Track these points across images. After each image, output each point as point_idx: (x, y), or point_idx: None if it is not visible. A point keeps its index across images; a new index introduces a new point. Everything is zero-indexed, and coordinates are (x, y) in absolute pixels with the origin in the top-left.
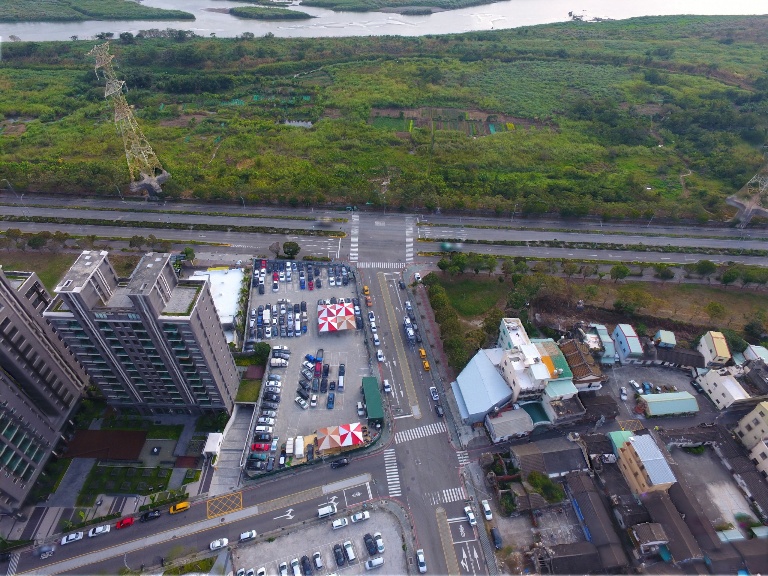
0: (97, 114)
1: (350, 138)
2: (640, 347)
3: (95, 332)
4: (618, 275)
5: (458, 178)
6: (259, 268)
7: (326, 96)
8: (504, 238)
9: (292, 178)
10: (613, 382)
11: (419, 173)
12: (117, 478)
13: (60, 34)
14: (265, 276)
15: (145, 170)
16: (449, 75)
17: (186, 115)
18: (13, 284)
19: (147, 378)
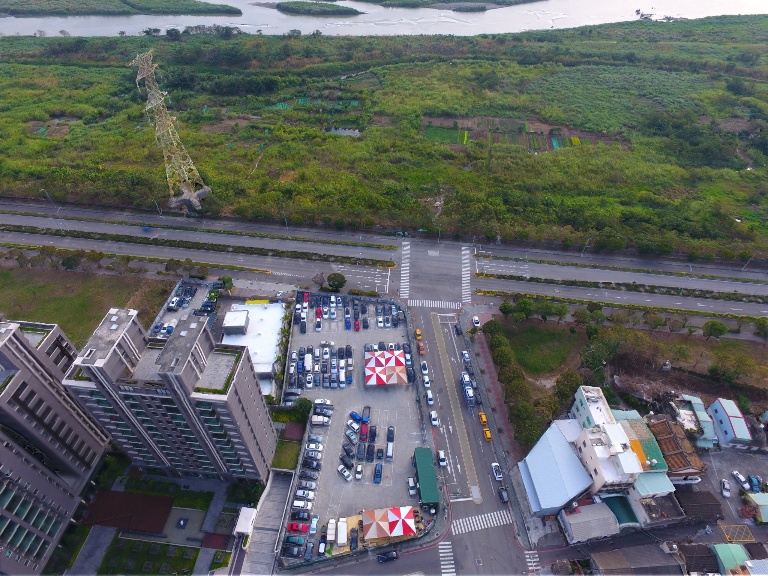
0: (140, 116)
1: (400, 150)
2: (747, 432)
3: (120, 402)
4: (712, 332)
5: (520, 202)
6: (301, 301)
7: (375, 101)
8: (574, 277)
9: (338, 195)
10: (711, 471)
11: (475, 193)
12: (139, 555)
13: (109, 29)
14: (307, 311)
15: (185, 186)
16: (507, 80)
17: (229, 119)
18: (34, 338)
19: (176, 446)
